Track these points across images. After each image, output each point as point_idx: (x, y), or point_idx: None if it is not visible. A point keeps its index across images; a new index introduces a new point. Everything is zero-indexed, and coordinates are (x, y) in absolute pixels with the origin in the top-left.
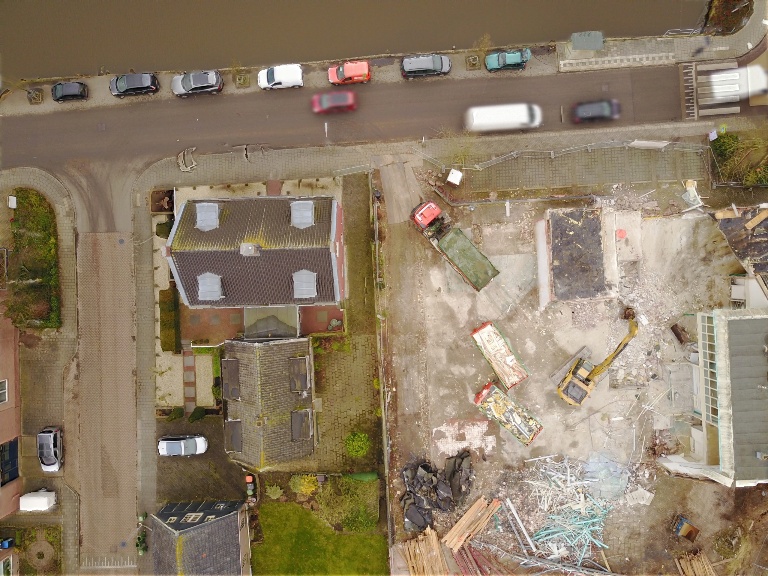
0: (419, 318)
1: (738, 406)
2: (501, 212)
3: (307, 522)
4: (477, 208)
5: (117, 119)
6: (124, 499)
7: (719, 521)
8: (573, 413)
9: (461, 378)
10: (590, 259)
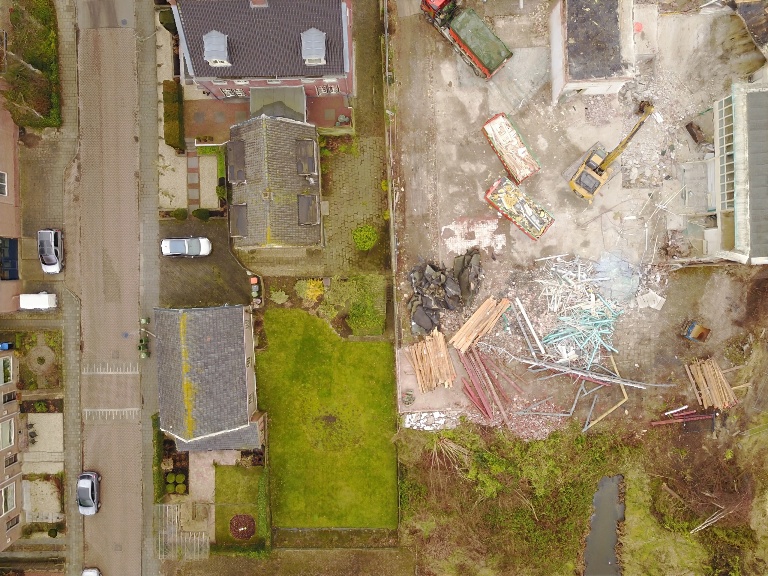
0: (429, 114)
1: (755, 181)
2: (514, 4)
3: (312, 329)
4: None
5: None
6: (126, 304)
7: (730, 328)
8: (585, 212)
9: (471, 175)
10: (606, 37)
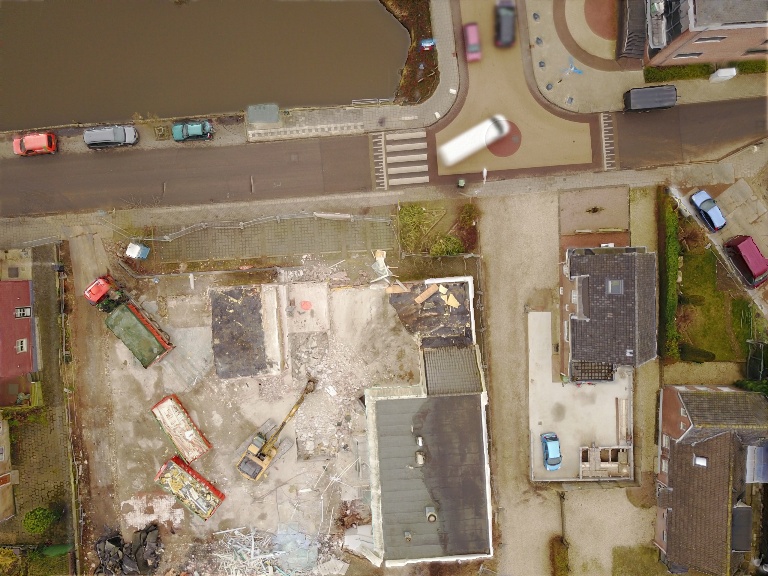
0: (107, 391)
1: (387, 486)
2: (186, 284)
3: None
4: (162, 280)
5: None
6: None
7: None
8: (261, 485)
9: (148, 451)
10: (250, 337)
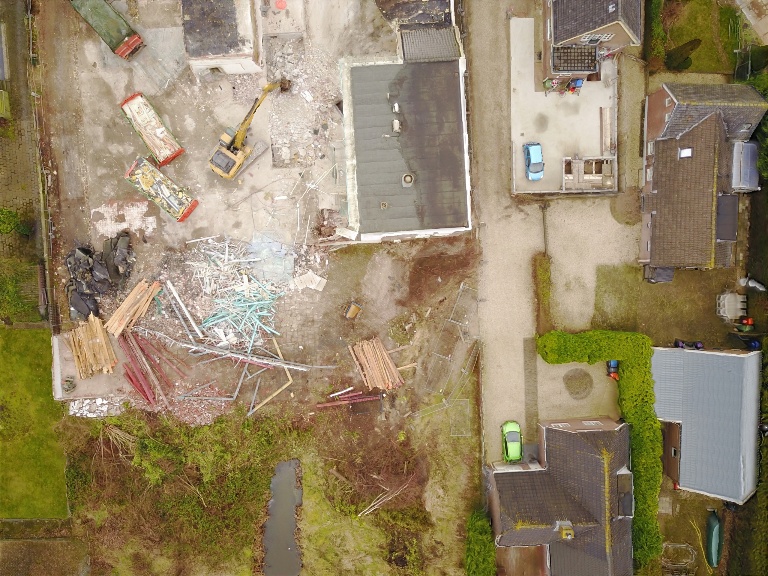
0: (76, 96)
1: (363, 157)
2: None
3: None
4: None
5: None
6: None
7: (394, 307)
8: (235, 192)
9: (119, 157)
10: (222, 13)
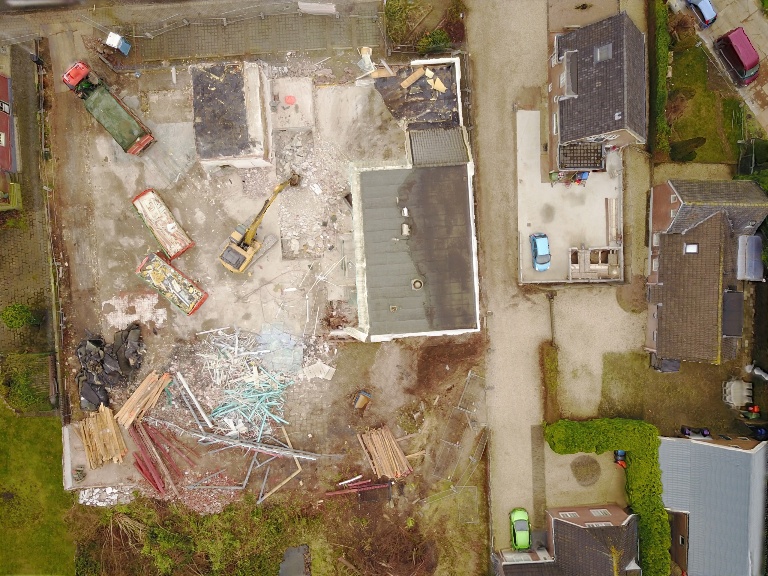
0: (87, 189)
1: (372, 260)
2: (168, 79)
3: None
4: (143, 75)
5: None
6: None
7: (403, 396)
8: (245, 284)
9: (130, 250)
10: (233, 116)
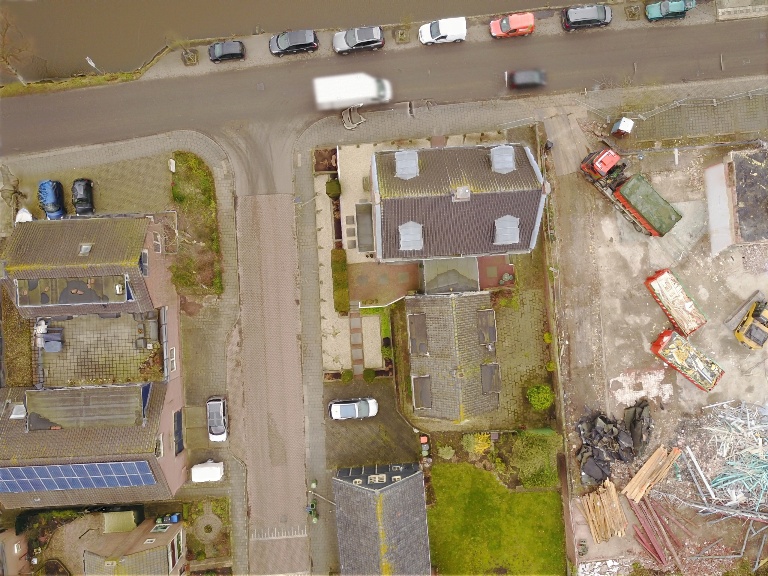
0: (591, 269)
1: None
2: (669, 160)
3: (480, 482)
4: (646, 157)
5: (276, 78)
6: (292, 467)
7: None
8: (748, 358)
9: (636, 328)
10: None
